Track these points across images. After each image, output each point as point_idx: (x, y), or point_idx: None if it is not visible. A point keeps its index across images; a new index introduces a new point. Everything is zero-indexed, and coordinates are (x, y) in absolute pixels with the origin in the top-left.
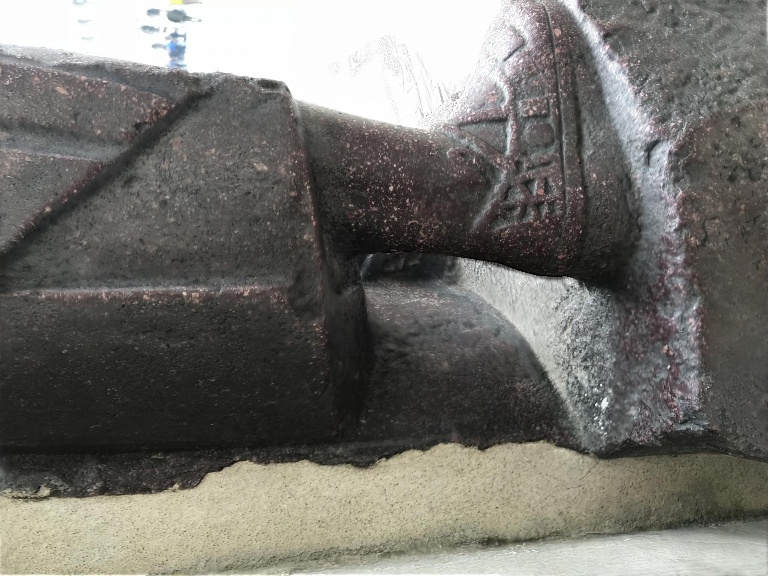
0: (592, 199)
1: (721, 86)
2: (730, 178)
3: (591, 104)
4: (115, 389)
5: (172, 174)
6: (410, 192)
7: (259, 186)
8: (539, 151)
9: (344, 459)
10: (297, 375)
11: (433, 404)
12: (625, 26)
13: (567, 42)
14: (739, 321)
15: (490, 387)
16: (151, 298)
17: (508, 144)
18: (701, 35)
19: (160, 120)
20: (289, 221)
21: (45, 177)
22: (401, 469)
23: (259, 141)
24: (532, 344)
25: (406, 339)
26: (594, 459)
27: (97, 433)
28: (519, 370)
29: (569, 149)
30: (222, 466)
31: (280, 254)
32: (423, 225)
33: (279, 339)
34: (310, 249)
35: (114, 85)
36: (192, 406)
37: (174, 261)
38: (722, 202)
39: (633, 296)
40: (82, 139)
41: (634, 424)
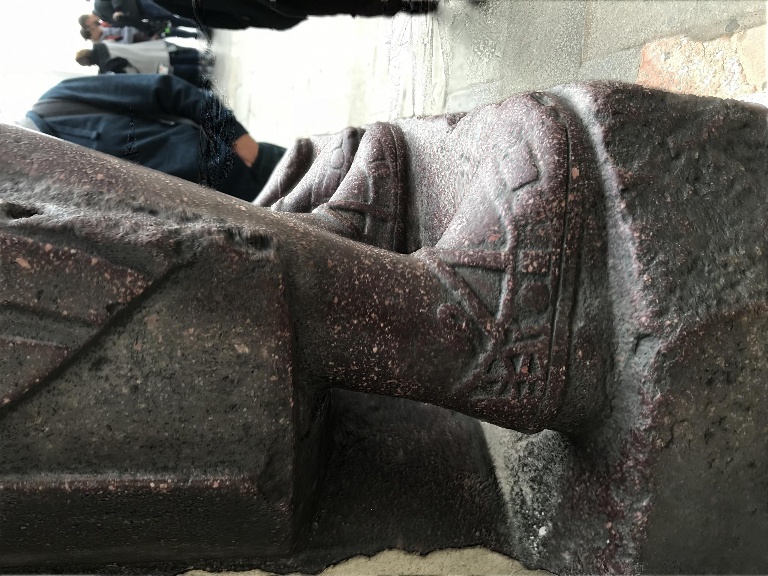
0: (573, 379)
1: (725, 278)
2: (709, 381)
3: (593, 265)
4: (75, 546)
5: (145, 356)
6: (394, 354)
7: (238, 370)
8: (531, 318)
9: (294, 569)
10: (259, 536)
11: (384, 503)
12: (646, 181)
13: (583, 187)
14: (681, 515)
15: (440, 483)
16: (117, 488)
17: (501, 304)
18: (720, 200)
19: (135, 299)
20: (266, 406)
21: (3, 365)
22: (346, 573)
23: (242, 319)
24: (486, 431)
25: (366, 415)
26: (523, 566)
27: (54, 562)
28: (469, 463)
29: (561, 319)
30: (176, 573)
31: (254, 440)
32: (402, 384)
33: (245, 516)
34: (285, 431)
35: (83, 257)
36: (152, 551)
37: (143, 447)
38: (695, 405)
39: (591, 461)
40: (45, 318)
41: (565, 566)
